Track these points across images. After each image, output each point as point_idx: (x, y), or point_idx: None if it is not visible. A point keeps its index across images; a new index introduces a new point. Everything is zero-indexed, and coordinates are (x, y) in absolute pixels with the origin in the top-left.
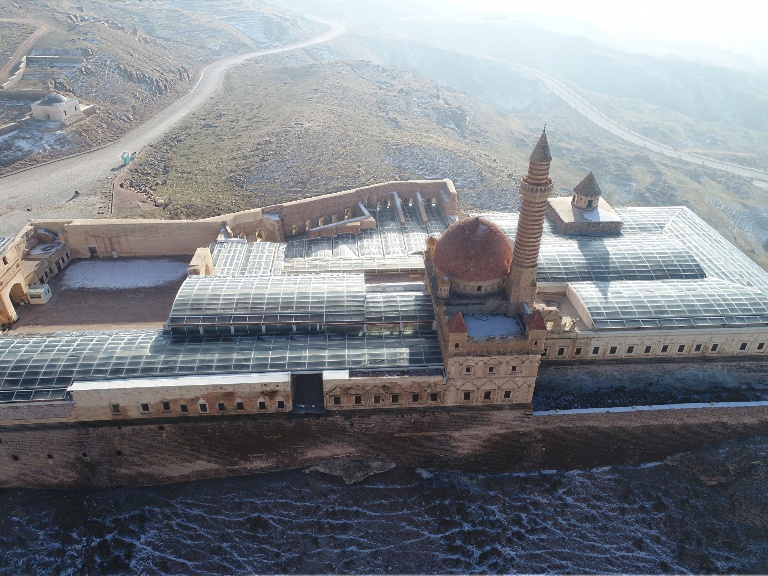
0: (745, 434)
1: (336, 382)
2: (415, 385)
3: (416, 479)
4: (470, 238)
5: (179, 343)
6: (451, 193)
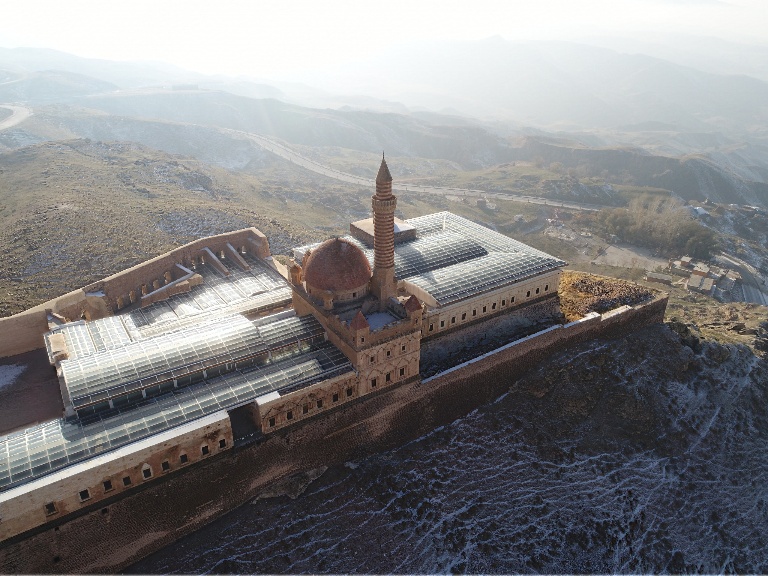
0: (549, 354)
1: (271, 404)
2: (334, 386)
3: (348, 472)
4: (338, 255)
5: (94, 422)
6: (261, 238)
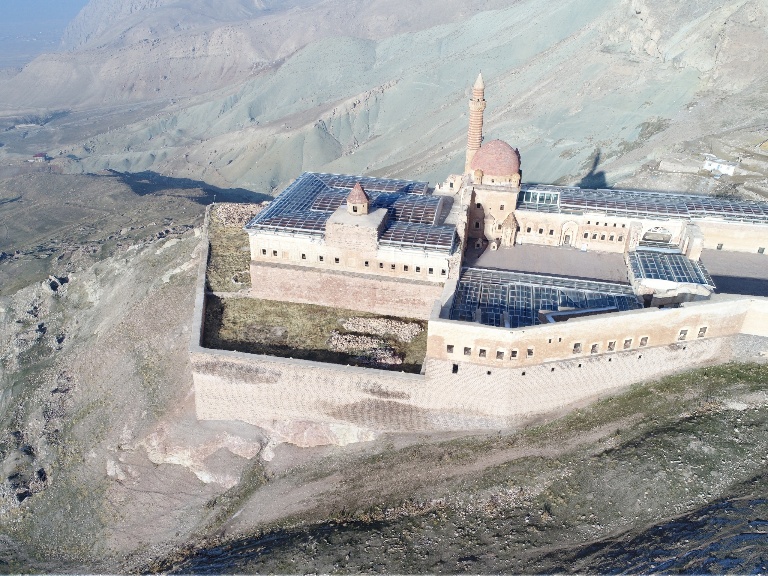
0: None
1: None
2: None
3: None
4: None
5: None
6: None
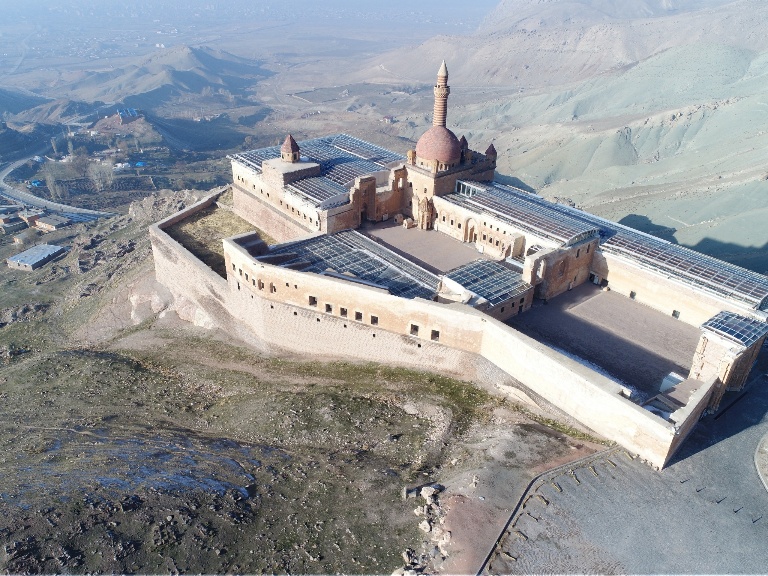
0: None
1: None
2: None
3: None
4: None
5: None
6: None
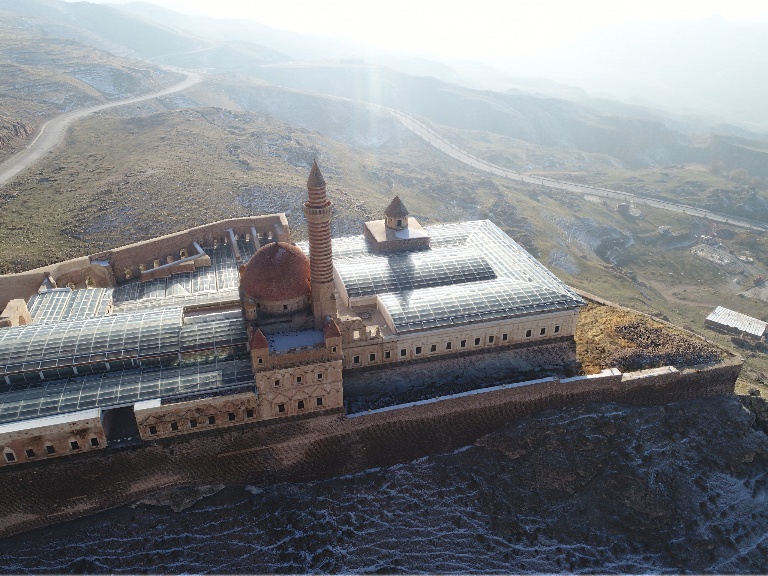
0: (537, 409)
1: (148, 411)
2: (228, 404)
3: (245, 496)
4: (270, 262)
5: None
6: (283, 226)
